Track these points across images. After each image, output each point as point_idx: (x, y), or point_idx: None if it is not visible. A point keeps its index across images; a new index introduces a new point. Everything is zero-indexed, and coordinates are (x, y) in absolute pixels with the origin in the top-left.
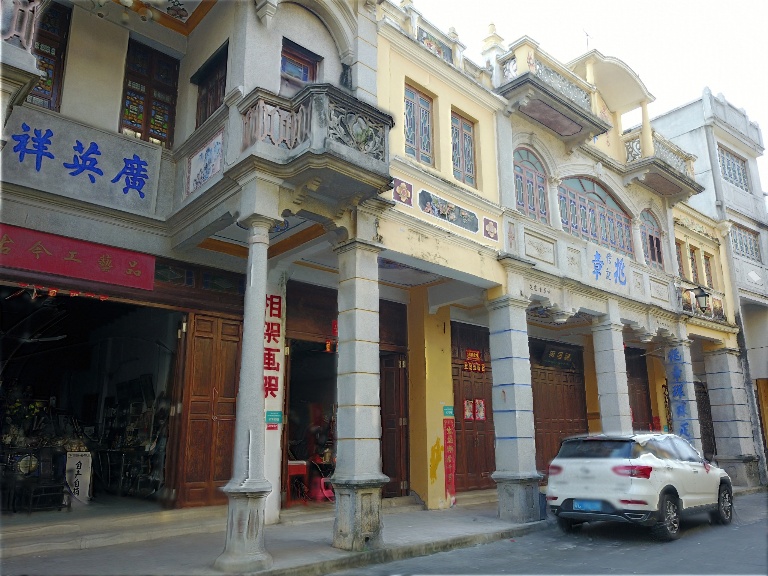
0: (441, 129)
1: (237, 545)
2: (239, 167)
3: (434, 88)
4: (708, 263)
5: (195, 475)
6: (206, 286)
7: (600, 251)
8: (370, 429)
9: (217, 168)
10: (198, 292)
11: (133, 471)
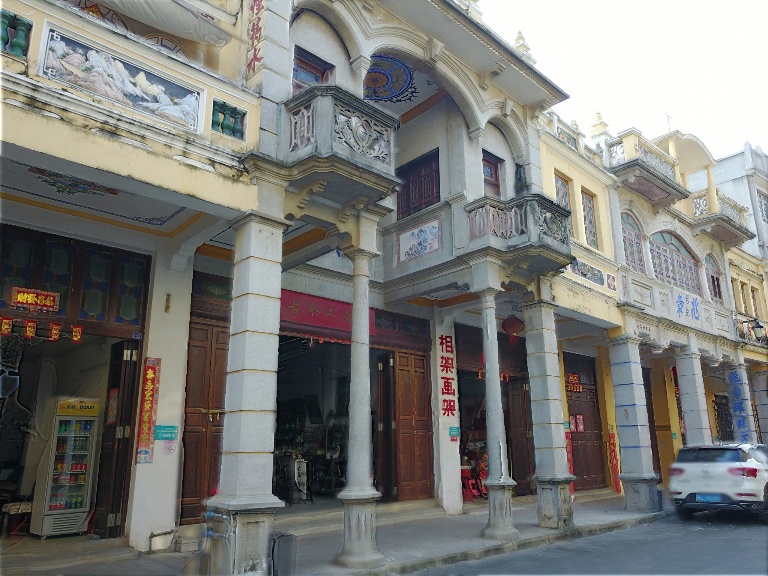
0: (577, 206)
1: (501, 522)
2: (473, 253)
3: (570, 174)
4: (753, 295)
5: (406, 476)
6: (404, 330)
7: (681, 293)
8: (560, 441)
9: (435, 247)
10: (400, 335)
11: (319, 475)
